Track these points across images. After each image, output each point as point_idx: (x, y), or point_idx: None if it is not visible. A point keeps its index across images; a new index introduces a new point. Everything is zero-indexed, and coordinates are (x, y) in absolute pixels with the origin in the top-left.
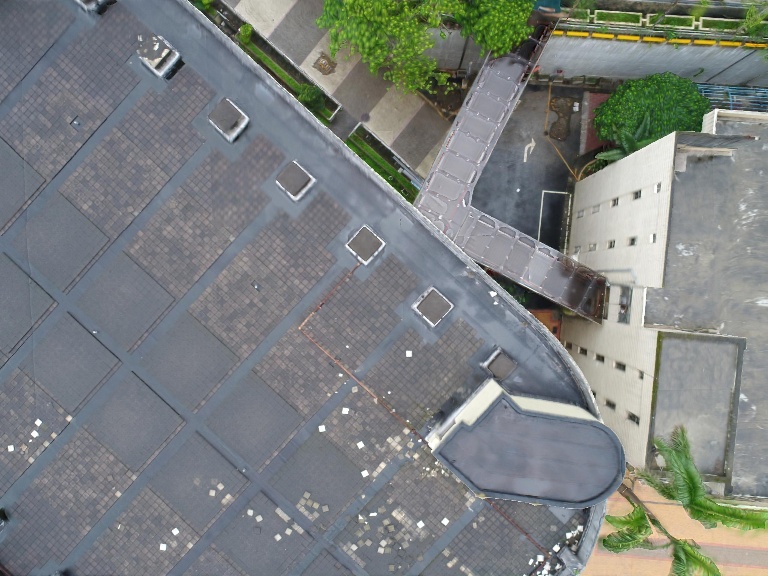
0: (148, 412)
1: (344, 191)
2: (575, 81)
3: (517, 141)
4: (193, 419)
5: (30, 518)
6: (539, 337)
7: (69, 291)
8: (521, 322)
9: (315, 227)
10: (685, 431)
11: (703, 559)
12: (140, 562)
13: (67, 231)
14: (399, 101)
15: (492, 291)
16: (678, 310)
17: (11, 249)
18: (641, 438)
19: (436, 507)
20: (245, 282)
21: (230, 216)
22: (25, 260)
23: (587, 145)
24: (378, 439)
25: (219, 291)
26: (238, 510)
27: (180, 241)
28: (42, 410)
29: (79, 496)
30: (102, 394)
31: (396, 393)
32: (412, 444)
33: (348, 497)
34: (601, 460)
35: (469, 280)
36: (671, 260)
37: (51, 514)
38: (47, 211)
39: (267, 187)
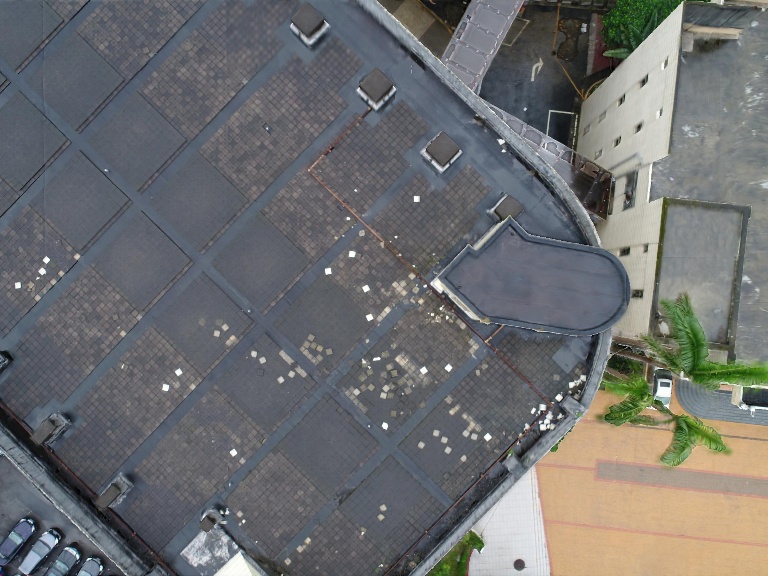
0: (156, 251)
1: (357, 37)
2: (583, 2)
3: (525, 60)
4: (200, 260)
5: (34, 356)
6: (546, 186)
7: (82, 130)
8: (528, 170)
9: (327, 72)
10: (689, 298)
11: (705, 428)
12: (142, 403)
13: (83, 70)
14: (410, 17)
15: (500, 139)
16: (683, 191)
17: (27, 87)
18: (645, 307)
19: (440, 353)
20: (256, 124)
21: (244, 59)
22: (40, 98)
23: (594, 66)
24: (384, 283)
25: (230, 133)
26: (242, 352)
27: (194, 83)
28: (51, 248)
29: (84, 335)
30: (111, 233)
31: (403, 238)
32: (417, 289)
33: (352, 341)
34: (606, 289)
35: (478, 127)
36: (677, 141)
37: (55, 353)
38: (64, 51)
39: (281, 32)
